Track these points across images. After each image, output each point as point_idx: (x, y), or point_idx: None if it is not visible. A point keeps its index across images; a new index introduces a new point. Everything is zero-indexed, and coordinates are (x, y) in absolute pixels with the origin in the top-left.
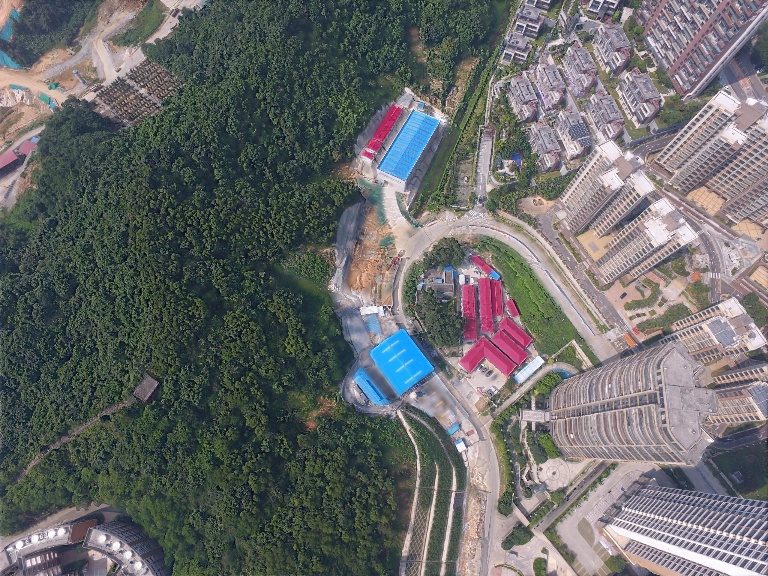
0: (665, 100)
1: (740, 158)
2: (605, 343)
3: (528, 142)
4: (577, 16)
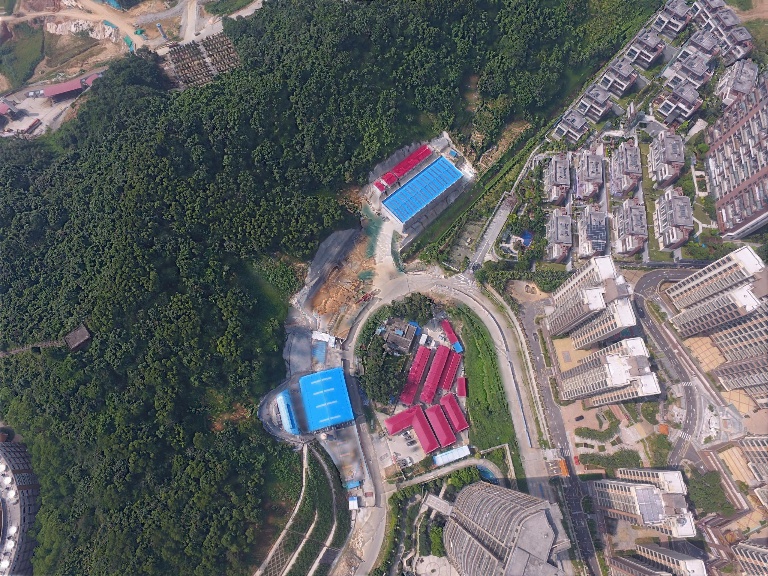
0: (702, 231)
1: (750, 324)
2: (539, 460)
3: (544, 225)
4: (642, 113)
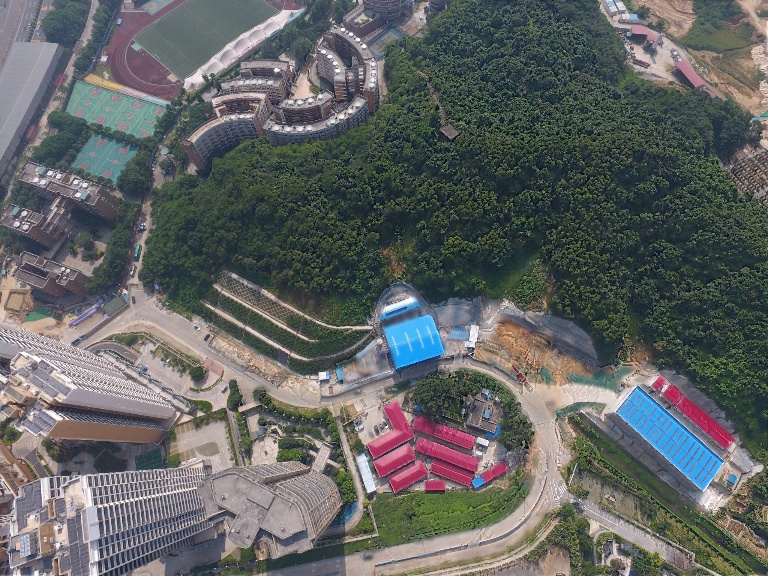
0: None
1: None
2: (363, 575)
3: None
4: None
